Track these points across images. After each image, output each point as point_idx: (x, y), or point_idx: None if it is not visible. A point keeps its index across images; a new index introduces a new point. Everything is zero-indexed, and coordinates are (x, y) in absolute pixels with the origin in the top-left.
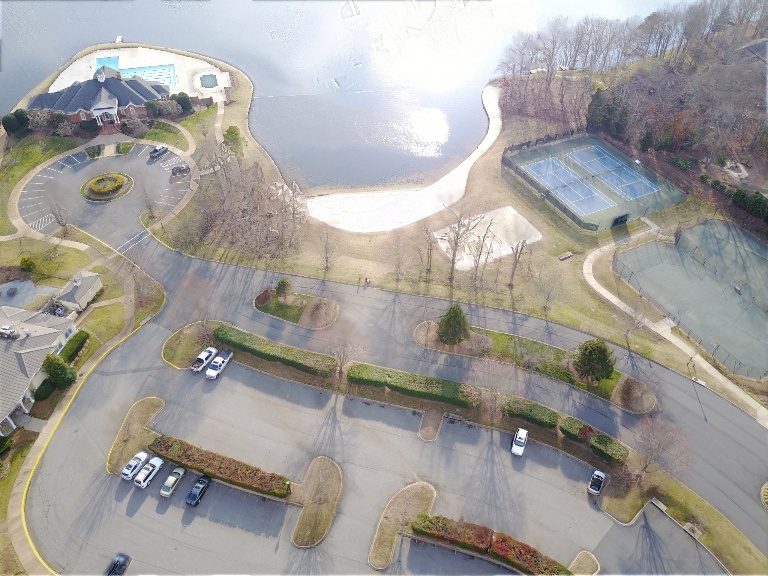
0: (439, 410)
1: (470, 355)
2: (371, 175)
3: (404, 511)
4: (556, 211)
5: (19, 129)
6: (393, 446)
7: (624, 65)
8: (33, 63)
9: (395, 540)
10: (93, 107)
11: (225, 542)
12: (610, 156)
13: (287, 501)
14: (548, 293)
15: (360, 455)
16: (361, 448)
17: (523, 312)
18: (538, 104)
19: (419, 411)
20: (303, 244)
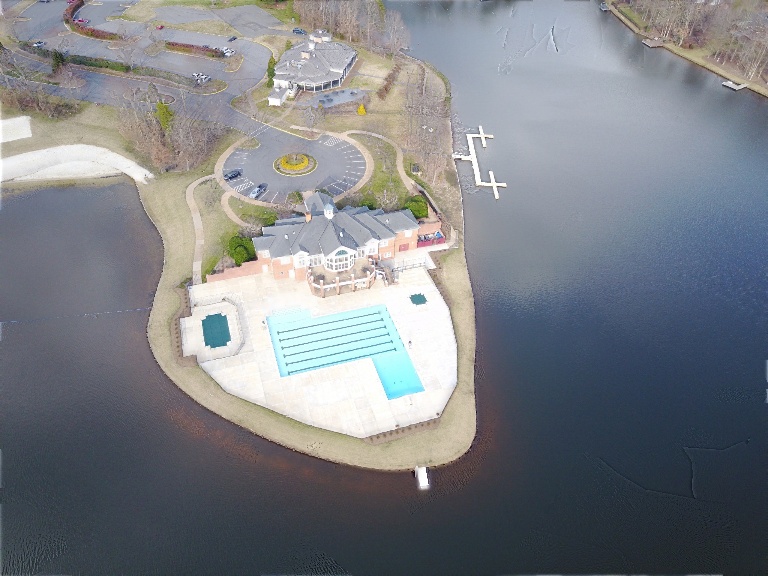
0: None
1: None
2: (47, 198)
3: None
4: None
5: None
6: None
7: None
8: None
9: None
10: None
11: (193, 42)
12: None
13: None
14: None
15: (135, 55)
16: (133, 56)
17: None
18: None
19: None
20: None
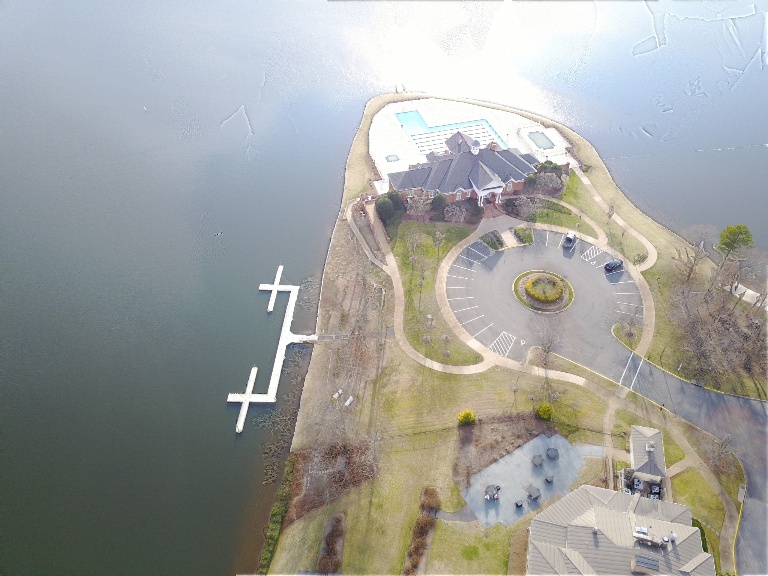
0: None
1: None
2: None
3: None
4: None
5: (394, 214)
6: None
7: None
8: (301, 116)
9: None
10: (482, 187)
11: None
12: None
13: None
14: None
15: None
16: None
17: None
18: None
19: None
20: None
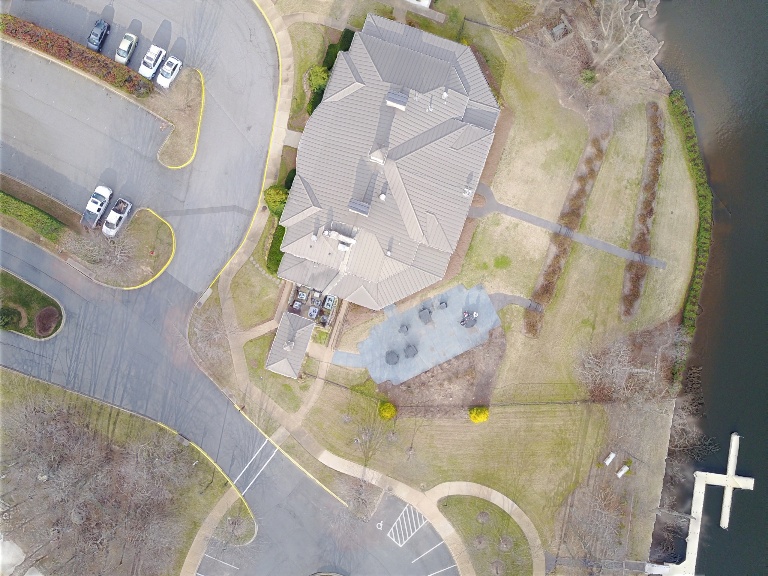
0: None
1: None
2: None
3: None
4: None
5: None
6: None
7: None
8: None
9: None
10: None
11: None
12: None
13: None
14: None
15: None
16: None
17: None
18: None
19: None
20: None
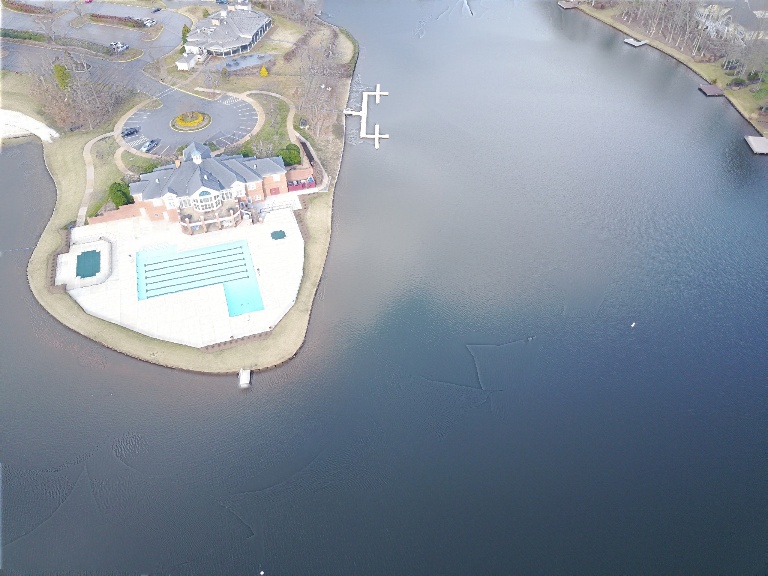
0: None
1: None
2: None
3: None
4: None
5: None
6: None
7: None
8: None
9: None
10: None
11: (119, 14)
12: None
13: None
14: None
15: (60, 27)
16: (58, 28)
17: None
18: None
19: None
20: None
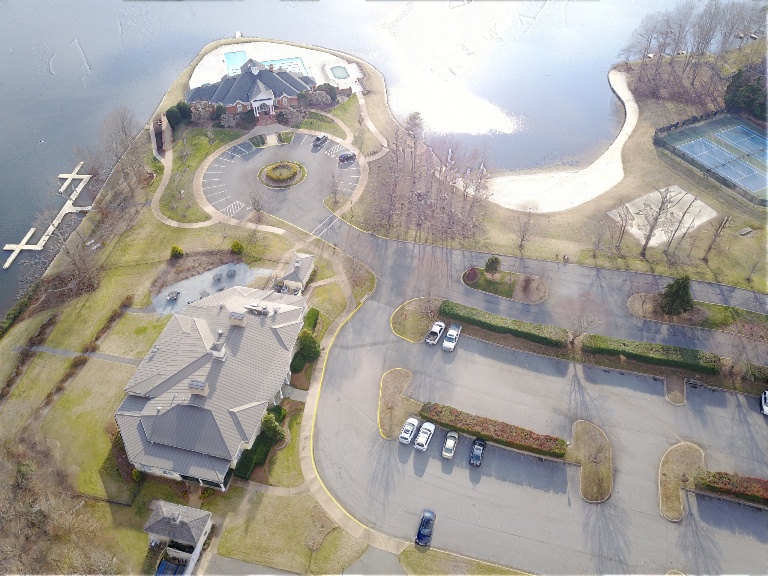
0: (679, 376)
1: (691, 325)
2: (525, 159)
3: (698, 466)
4: (723, 189)
5: (182, 121)
6: (646, 410)
7: (767, 46)
8: (154, 60)
9: (681, 495)
10: (253, 98)
11: (518, 498)
12: (758, 135)
13: (564, 461)
14: (754, 265)
15: (617, 418)
16: (616, 412)
17: (728, 284)
18: (669, 87)
19: (659, 377)
20: (486, 225)
